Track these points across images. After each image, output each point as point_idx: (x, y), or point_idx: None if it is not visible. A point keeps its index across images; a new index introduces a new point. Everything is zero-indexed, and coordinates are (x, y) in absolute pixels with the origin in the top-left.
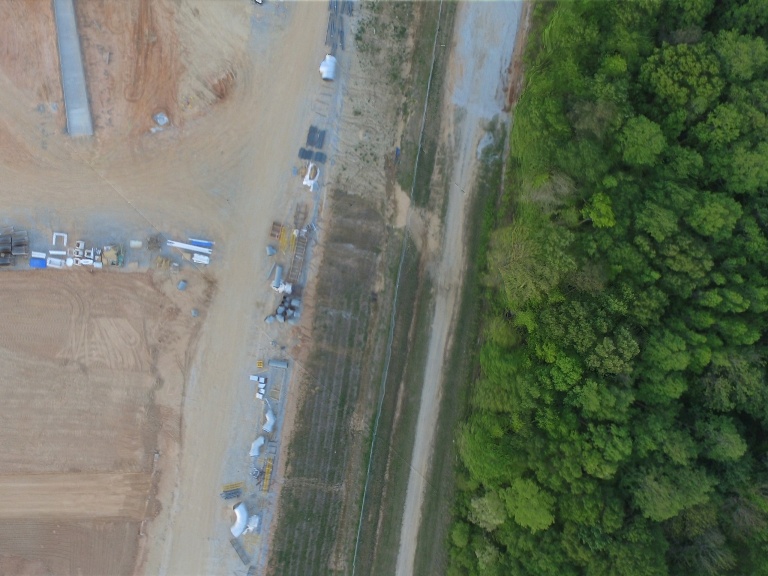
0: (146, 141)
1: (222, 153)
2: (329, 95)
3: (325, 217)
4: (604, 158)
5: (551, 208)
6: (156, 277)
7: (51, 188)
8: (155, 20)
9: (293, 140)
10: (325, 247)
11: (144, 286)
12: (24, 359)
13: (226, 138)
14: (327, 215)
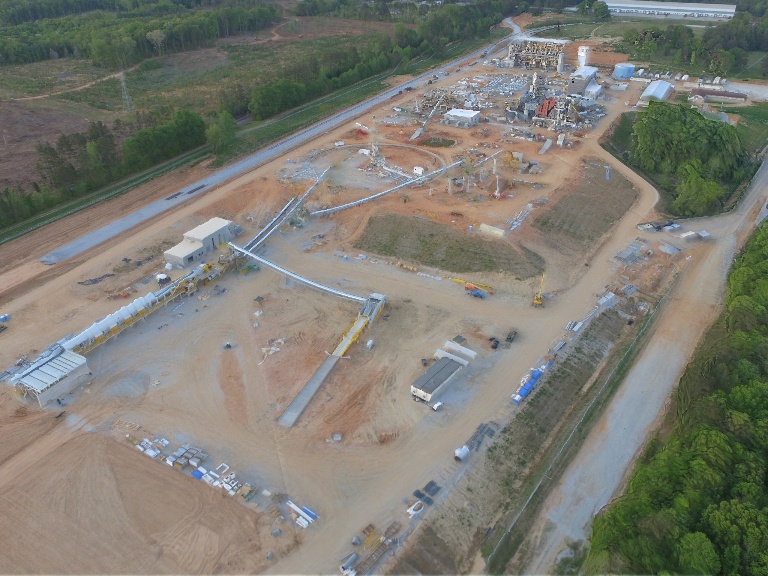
0: (319, 443)
1: (362, 470)
2: (454, 470)
3: (411, 540)
4: (660, 554)
5: (604, 570)
6: (262, 519)
7: (243, 441)
8: (368, 395)
9: (415, 483)
10: (399, 561)
11: (250, 521)
12: (130, 525)
13: (370, 463)
14: (413, 540)
